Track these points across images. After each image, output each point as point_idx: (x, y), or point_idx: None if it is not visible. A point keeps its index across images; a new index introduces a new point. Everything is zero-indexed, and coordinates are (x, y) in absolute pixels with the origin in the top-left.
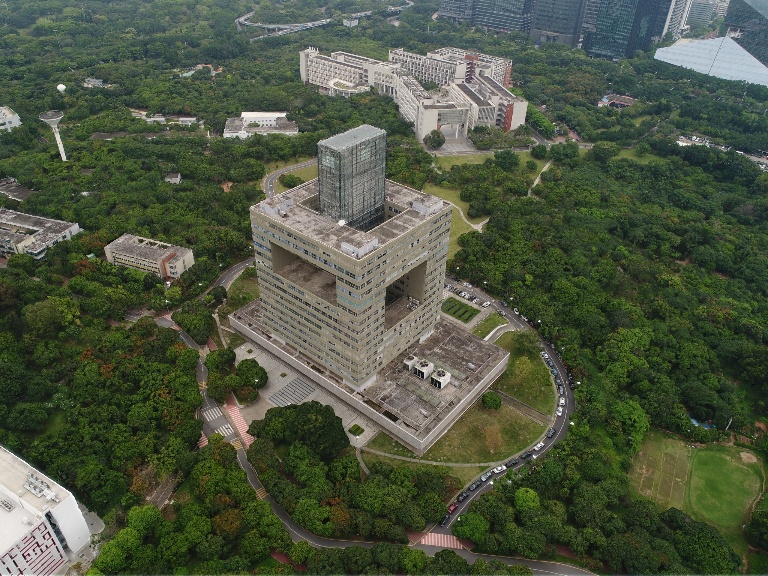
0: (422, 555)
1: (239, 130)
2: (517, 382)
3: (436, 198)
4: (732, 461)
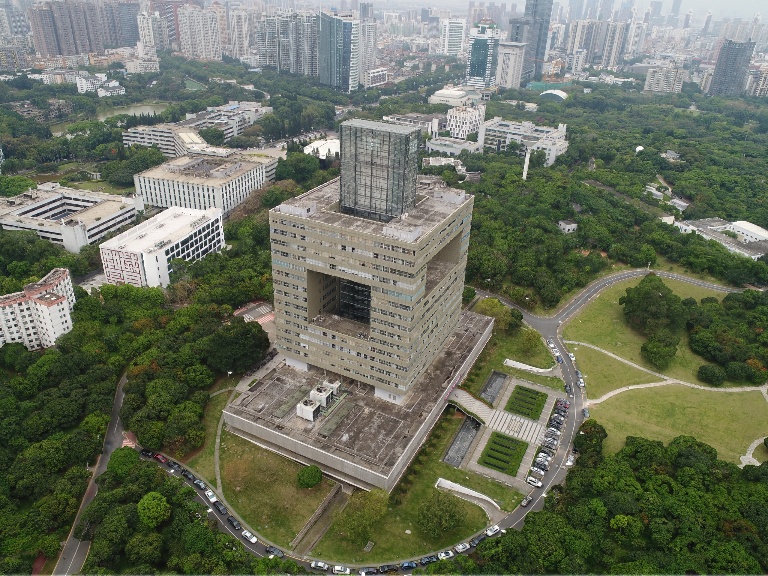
0: (96, 426)
1: (698, 227)
2: (347, 499)
3: (411, 229)
4: None
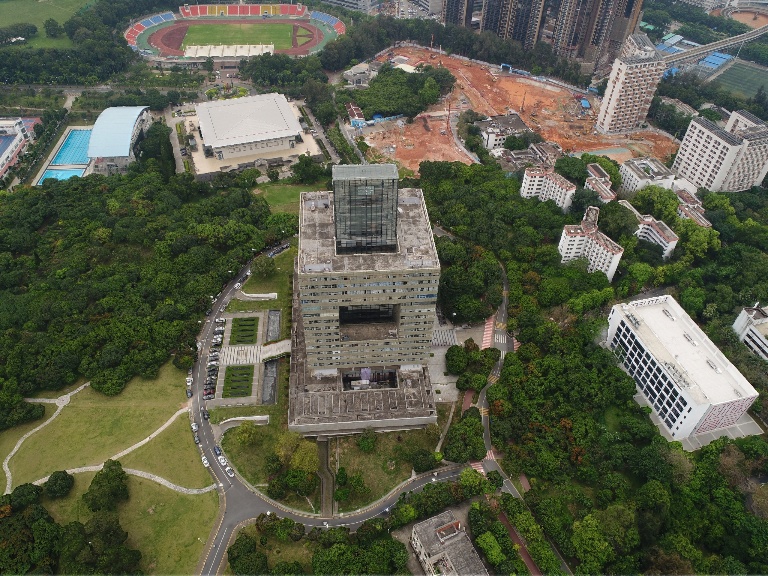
0: None
1: None
2: None
3: (309, 195)
4: (266, 194)
